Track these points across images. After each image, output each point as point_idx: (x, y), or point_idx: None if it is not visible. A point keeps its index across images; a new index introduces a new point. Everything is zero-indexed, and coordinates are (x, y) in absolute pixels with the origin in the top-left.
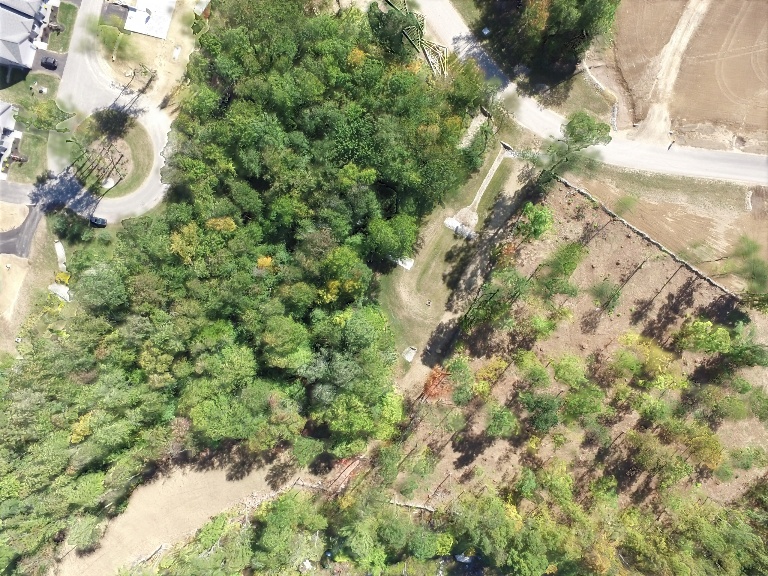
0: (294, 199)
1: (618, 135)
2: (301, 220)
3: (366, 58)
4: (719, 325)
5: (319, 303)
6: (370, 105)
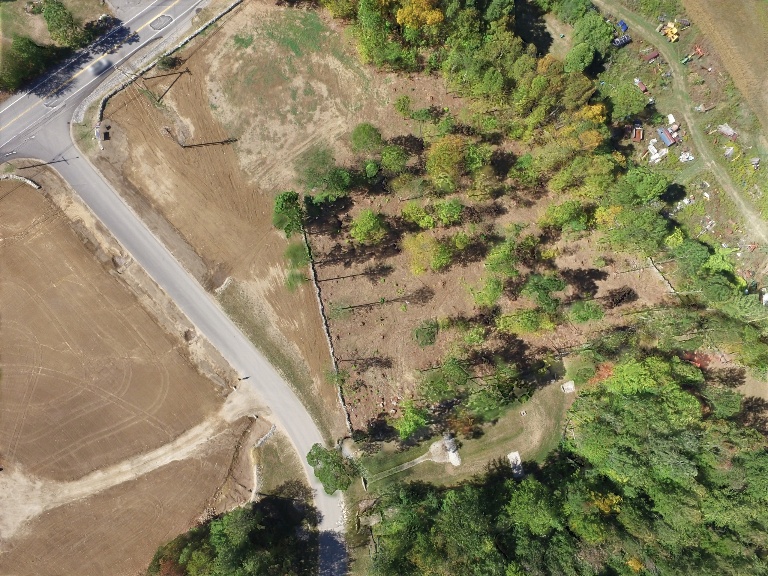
0: None
1: (276, 421)
2: None
3: None
4: None
5: None
6: None
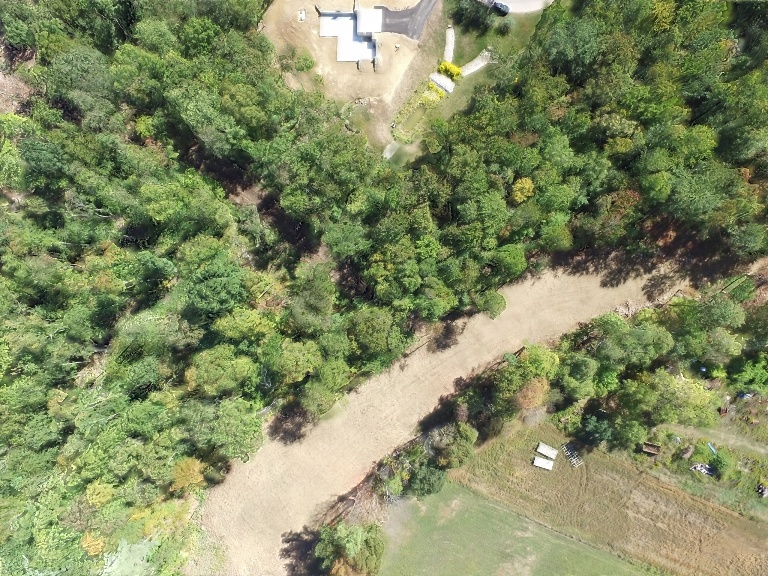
0: None
1: None
2: None
3: None
4: None
5: None
6: None
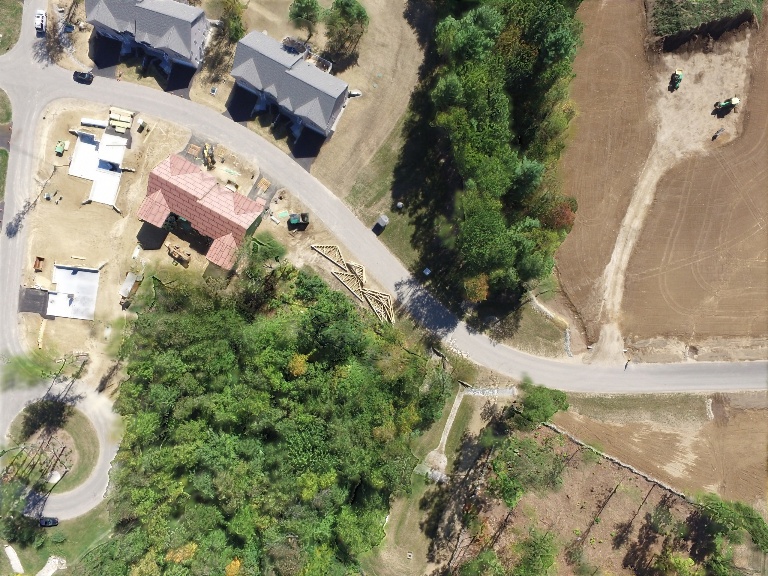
0: (254, 512)
1: (574, 361)
2: (265, 530)
3: (308, 364)
4: (699, 542)
5: None
6: (319, 409)
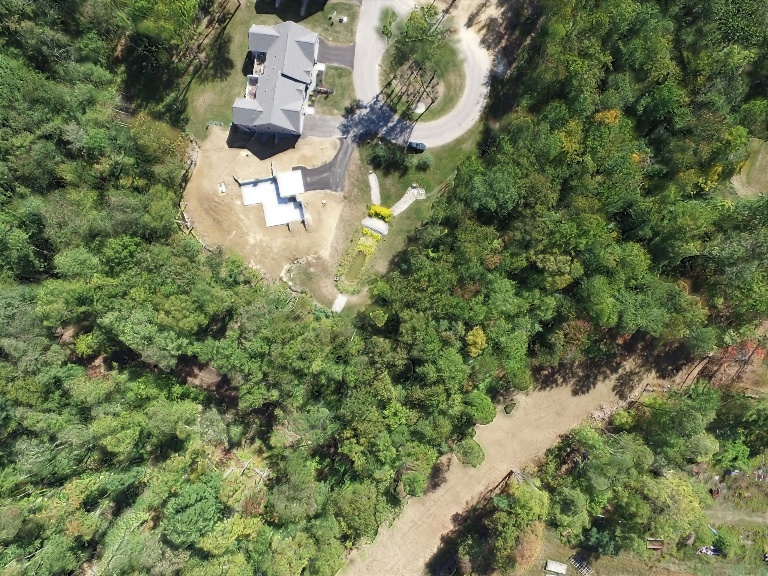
0: (672, 88)
1: None
2: (678, 109)
3: None
4: None
5: (693, 193)
6: None
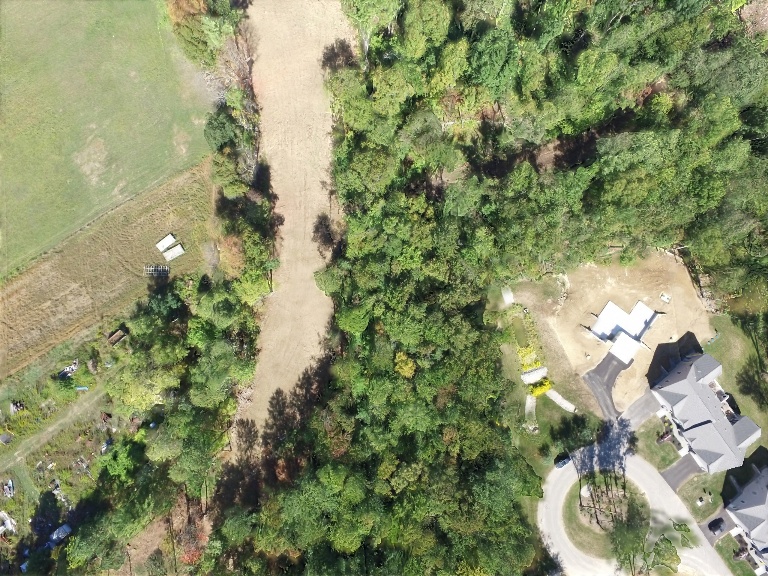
0: None
1: None
2: None
3: None
4: None
5: None
6: None
